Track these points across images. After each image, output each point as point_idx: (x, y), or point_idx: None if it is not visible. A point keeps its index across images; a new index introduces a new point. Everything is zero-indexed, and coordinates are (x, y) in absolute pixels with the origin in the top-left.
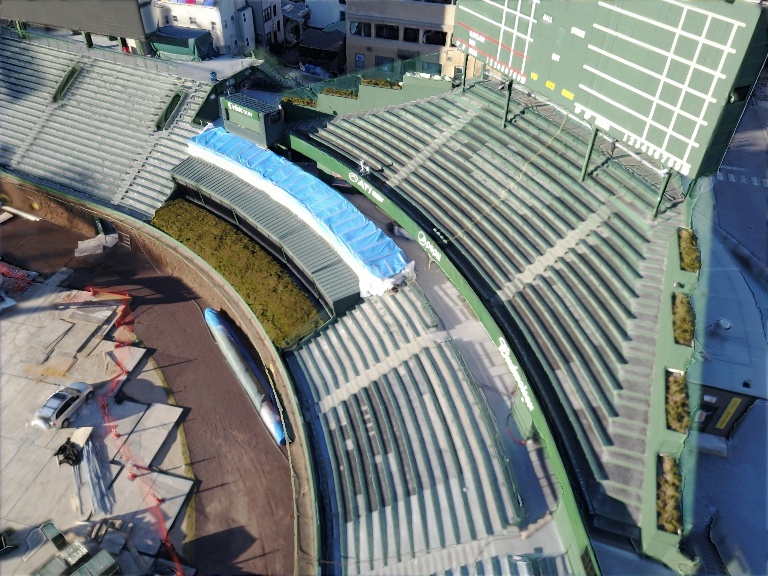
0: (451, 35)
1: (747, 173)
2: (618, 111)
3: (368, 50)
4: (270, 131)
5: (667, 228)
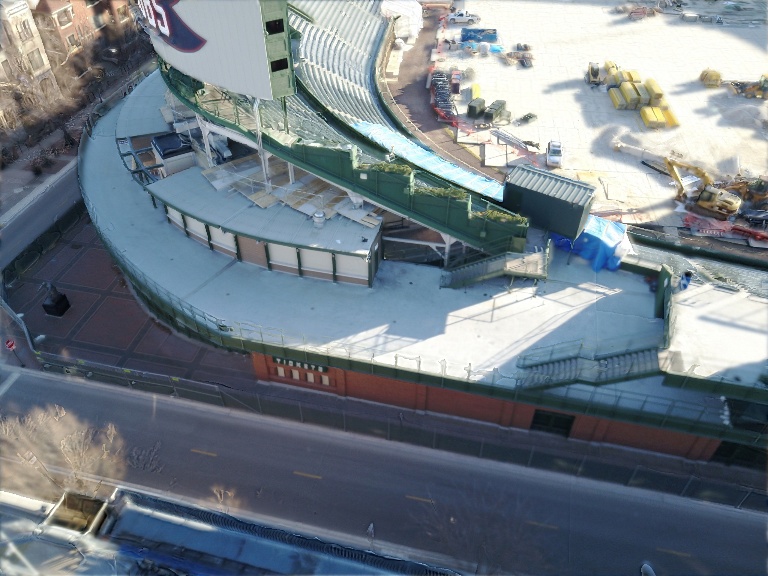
0: None
1: None
2: None
3: None
4: None
5: None
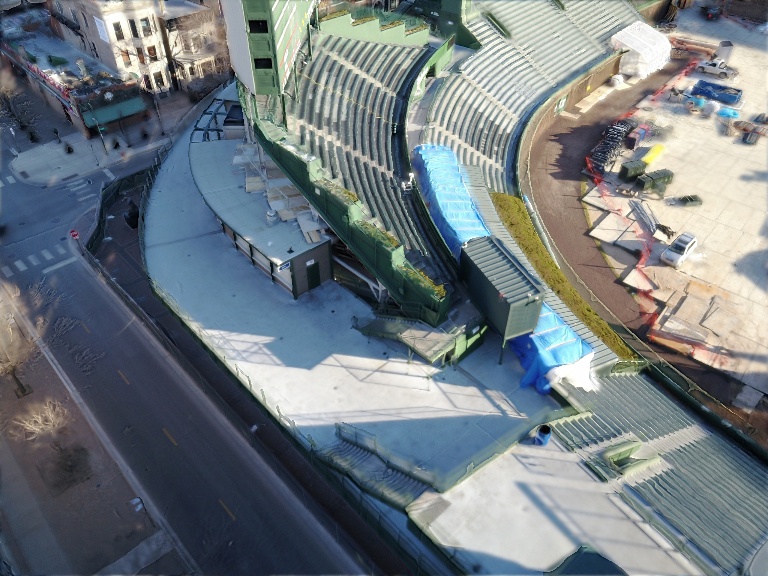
0: None
1: None
2: None
3: None
4: None
5: None
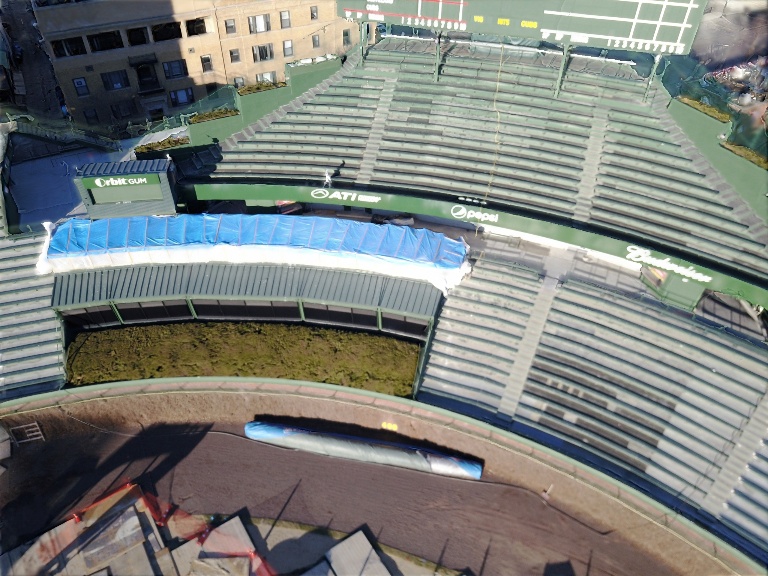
0: (185, 23)
1: None
2: (598, 22)
3: (89, 70)
4: (172, 190)
5: (659, 103)
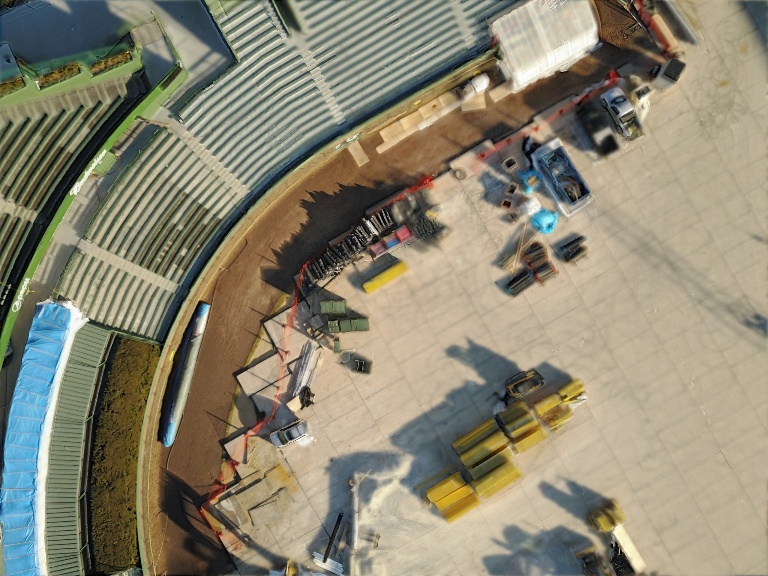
0: None
1: None
2: None
3: None
4: None
5: None
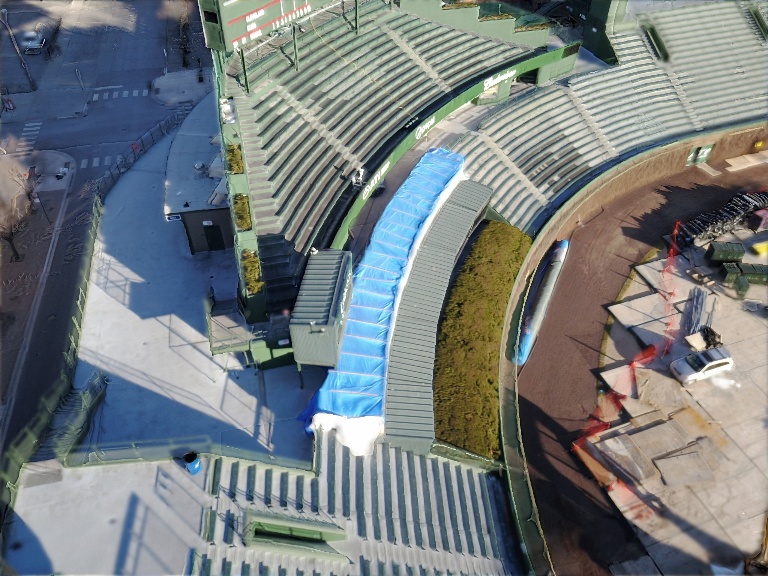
0: None
1: (14, 137)
2: None
3: None
4: None
5: None
